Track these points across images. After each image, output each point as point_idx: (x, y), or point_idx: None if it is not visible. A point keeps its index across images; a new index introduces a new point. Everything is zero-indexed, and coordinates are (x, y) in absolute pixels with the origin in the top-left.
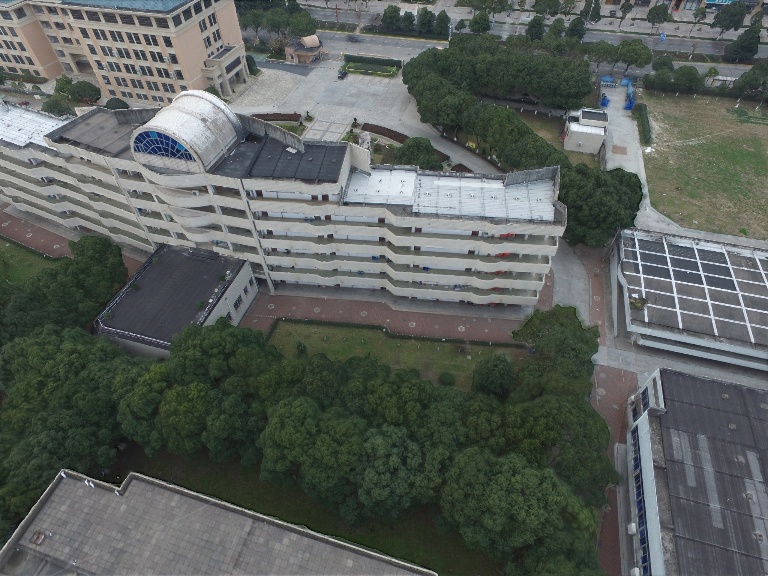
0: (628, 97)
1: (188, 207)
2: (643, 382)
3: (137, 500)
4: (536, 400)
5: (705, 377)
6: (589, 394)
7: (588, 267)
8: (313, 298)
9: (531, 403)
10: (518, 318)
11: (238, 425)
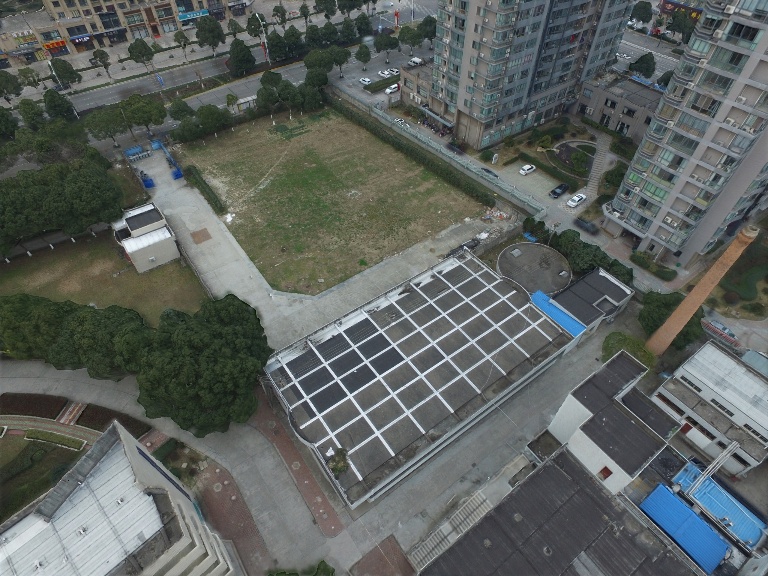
0: (170, 163)
1: None
2: (404, 541)
3: None
4: None
5: (458, 538)
6: None
7: (261, 428)
8: None
9: None
10: None
11: None
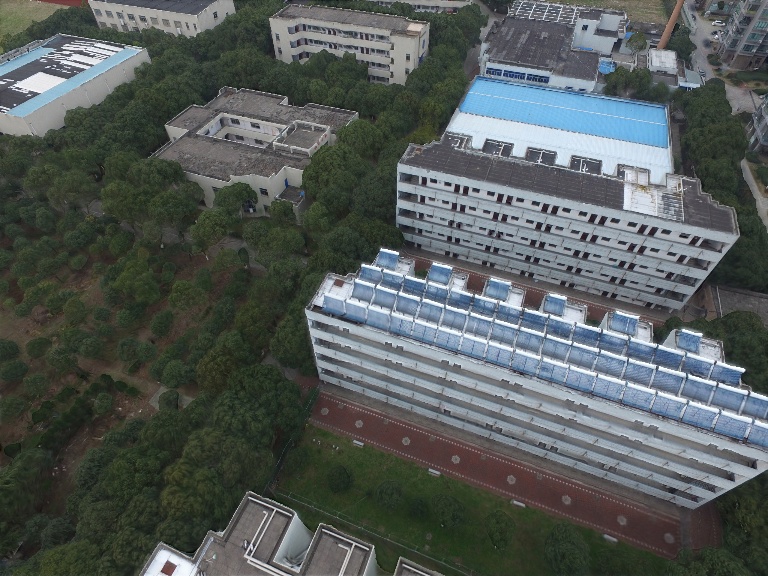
0: None
1: None
2: None
3: (316, 9)
4: None
5: (522, 18)
6: (475, 19)
7: None
8: None
9: None
10: None
11: None
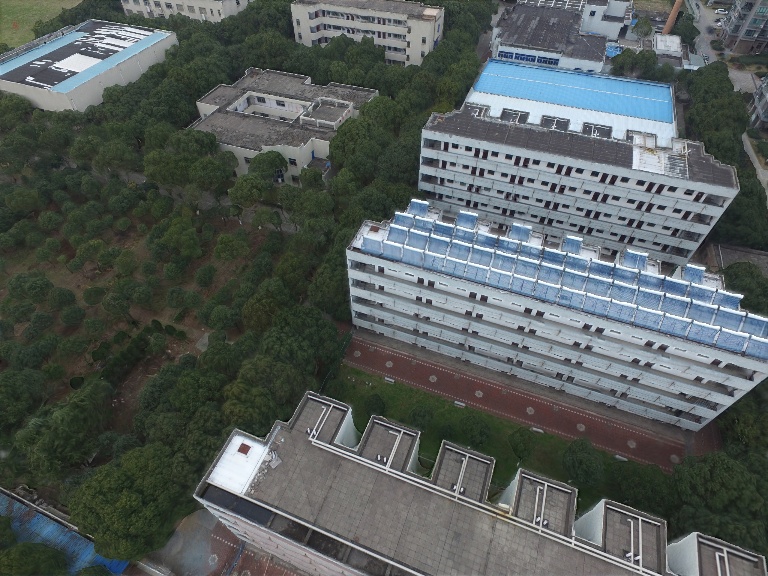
0: None
1: None
2: None
3: None
4: None
5: (532, 5)
6: (486, 6)
7: None
8: None
9: None
10: None
11: None
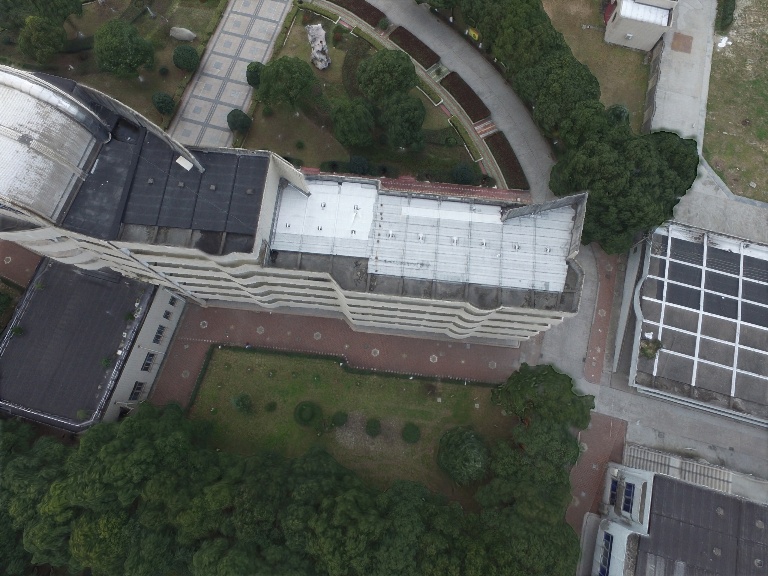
0: None
1: (50, 251)
2: (632, 434)
3: None
4: (504, 520)
5: (704, 487)
6: None
7: (600, 263)
8: (255, 312)
9: (498, 522)
10: (502, 344)
11: (162, 566)
